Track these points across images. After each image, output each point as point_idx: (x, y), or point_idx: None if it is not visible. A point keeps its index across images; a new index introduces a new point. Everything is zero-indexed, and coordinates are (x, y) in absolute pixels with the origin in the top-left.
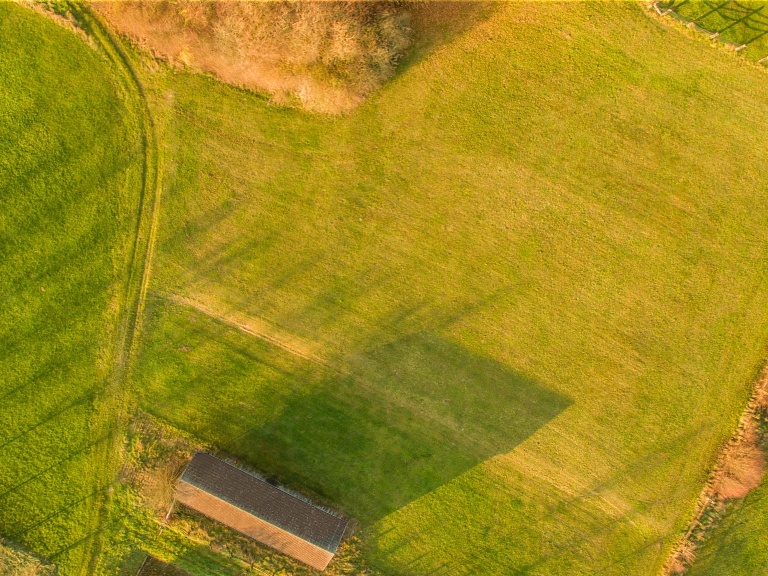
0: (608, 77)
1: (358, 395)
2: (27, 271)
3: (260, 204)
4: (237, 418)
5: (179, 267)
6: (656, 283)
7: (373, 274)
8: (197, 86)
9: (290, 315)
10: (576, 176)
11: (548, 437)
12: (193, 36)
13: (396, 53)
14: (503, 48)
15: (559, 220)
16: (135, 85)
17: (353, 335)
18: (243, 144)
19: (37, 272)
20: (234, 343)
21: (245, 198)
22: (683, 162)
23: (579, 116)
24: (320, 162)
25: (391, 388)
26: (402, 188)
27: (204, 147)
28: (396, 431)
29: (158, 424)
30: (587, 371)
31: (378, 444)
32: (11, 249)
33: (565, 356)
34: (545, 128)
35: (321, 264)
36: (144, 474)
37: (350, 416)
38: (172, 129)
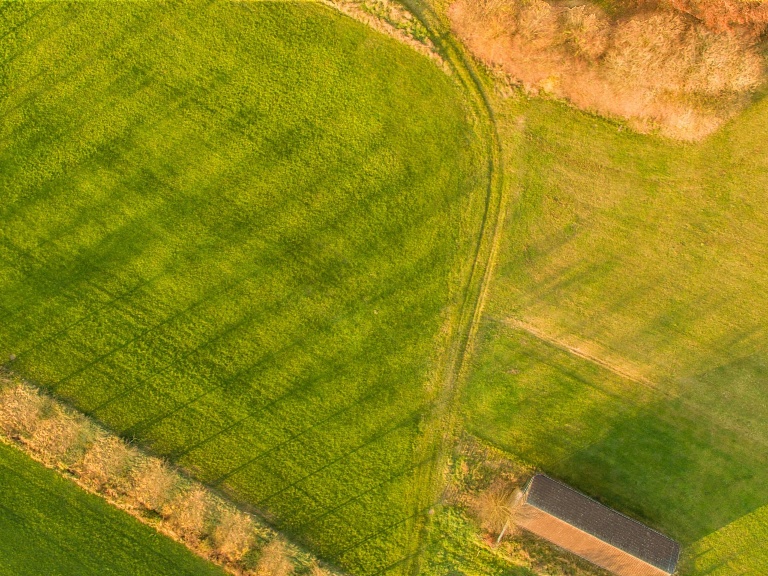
0: None
1: (684, 417)
2: (361, 294)
3: (603, 229)
4: (562, 440)
5: (517, 291)
6: None
7: (710, 298)
8: (549, 112)
9: (624, 338)
10: None
11: None
12: (575, 64)
13: (756, 81)
14: None
15: None
16: (486, 110)
17: (685, 358)
18: (590, 169)
19: (371, 295)
20: (563, 366)
21: (588, 223)
22: None
23: None
24: (666, 188)
25: (718, 410)
26: (746, 214)
27: (551, 172)
28: (719, 453)
29: (483, 446)
30: None
31: (701, 466)
32: (346, 272)
33: None
34: None
35: (659, 288)
36: (467, 496)
37: (674, 438)
38: (520, 154)
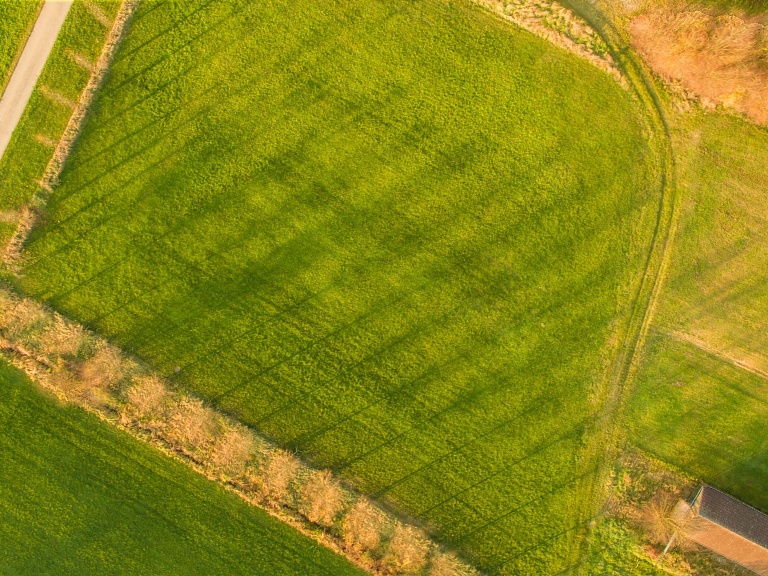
0: None
1: None
2: (529, 307)
3: None
4: (724, 452)
5: (685, 304)
6: None
7: None
8: (725, 127)
9: None
10: None
11: None
12: (766, 81)
13: None
14: None
15: None
16: (662, 125)
17: None
18: (763, 184)
19: (539, 308)
20: (727, 378)
21: (759, 236)
22: None
23: None
24: None
25: None
26: None
27: (724, 186)
28: None
29: (645, 458)
30: None
31: None
32: (515, 285)
33: None
34: None
35: None
36: (629, 507)
37: None
38: (694, 168)
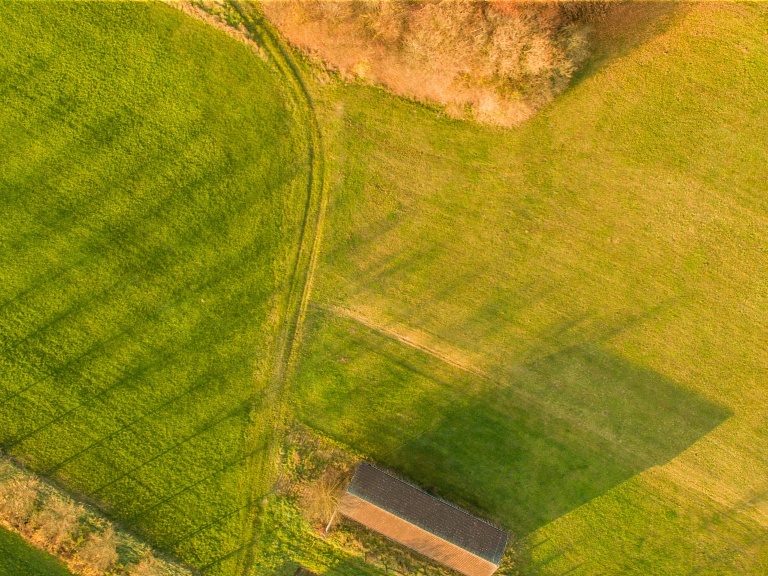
0: None
1: (516, 407)
2: (187, 282)
3: (426, 216)
4: (394, 429)
5: (342, 279)
6: None
7: (537, 286)
8: (367, 98)
9: (452, 327)
10: (745, 189)
11: (706, 449)
12: (378, 49)
13: (571, 66)
14: (679, 61)
15: (726, 232)
16: (304, 97)
17: (514, 347)
18: (411, 156)
19: (197, 283)
20: (393, 354)
21: (411, 210)
22: None
23: (752, 129)
24: (488, 174)
25: (550, 400)
26: (569, 200)
27: (372, 159)
28: (553, 442)
29: (314, 435)
30: (748, 383)
31: (535, 455)
32: (172, 260)
33: (726, 368)
34: (717, 141)
35: (485, 276)
36: (300, 486)
37: (507, 427)
38: (340, 141)
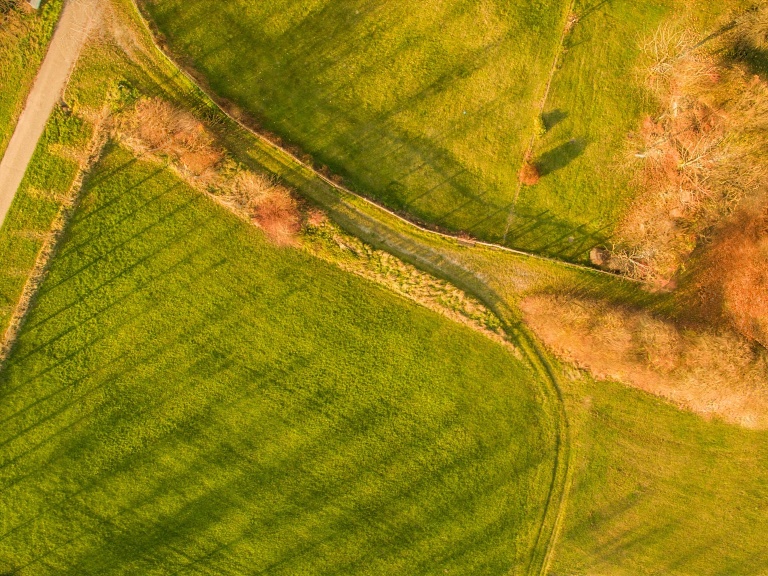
0: None
1: None
2: (432, 555)
3: (663, 495)
4: None
5: (581, 552)
6: None
7: (763, 555)
8: (615, 392)
9: None
10: None
11: None
12: (646, 370)
13: None
14: None
15: None
16: (555, 391)
17: None
18: (653, 443)
19: (442, 556)
20: None
21: (650, 490)
22: None
23: None
24: (724, 459)
25: None
26: None
27: (615, 446)
28: None
29: None
30: None
31: None
32: (419, 536)
33: None
34: None
35: (715, 547)
36: None
37: None
38: (587, 430)
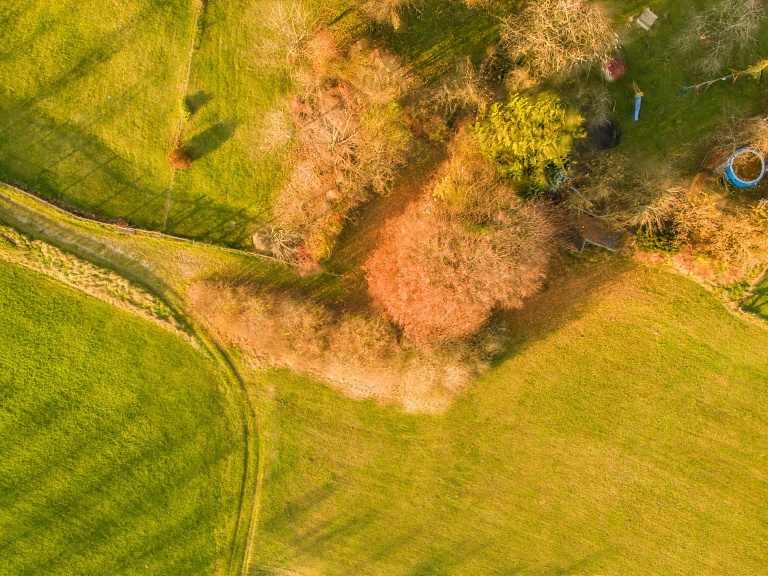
0: (693, 367)
1: None
2: (131, 550)
3: (359, 485)
4: None
5: (281, 544)
6: (737, 545)
7: (468, 544)
8: (297, 380)
9: None
10: (662, 453)
11: None
12: (302, 356)
13: (492, 351)
14: (594, 344)
15: (646, 492)
16: (237, 380)
17: None
18: (342, 431)
19: (140, 551)
20: None
21: (345, 480)
22: (763, 440)
23: (666, 402)
24: (417, 446)
25: None
26: (496, 467)
27: (304, 435)
28: None
29: None
30: None
31: None
32: (115, 531)
33: None
34: (633, 413)
35: (419, 537)
36: None
37: None
38: (273, 419)
